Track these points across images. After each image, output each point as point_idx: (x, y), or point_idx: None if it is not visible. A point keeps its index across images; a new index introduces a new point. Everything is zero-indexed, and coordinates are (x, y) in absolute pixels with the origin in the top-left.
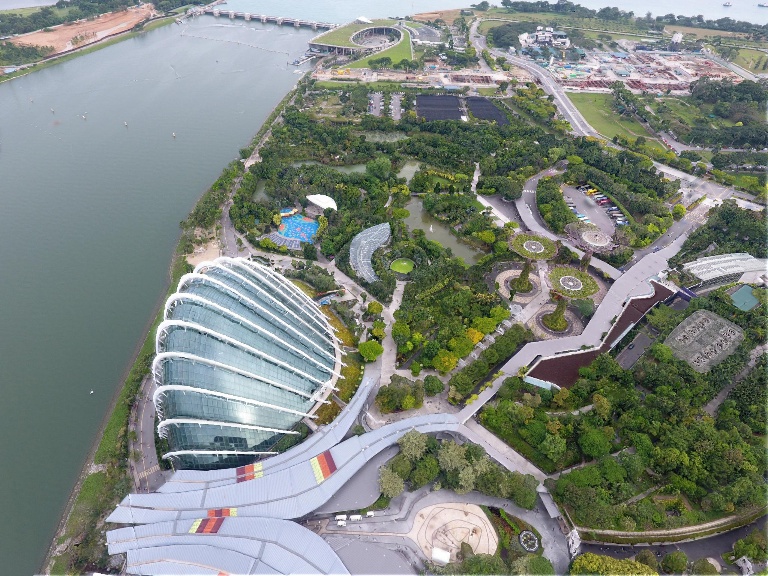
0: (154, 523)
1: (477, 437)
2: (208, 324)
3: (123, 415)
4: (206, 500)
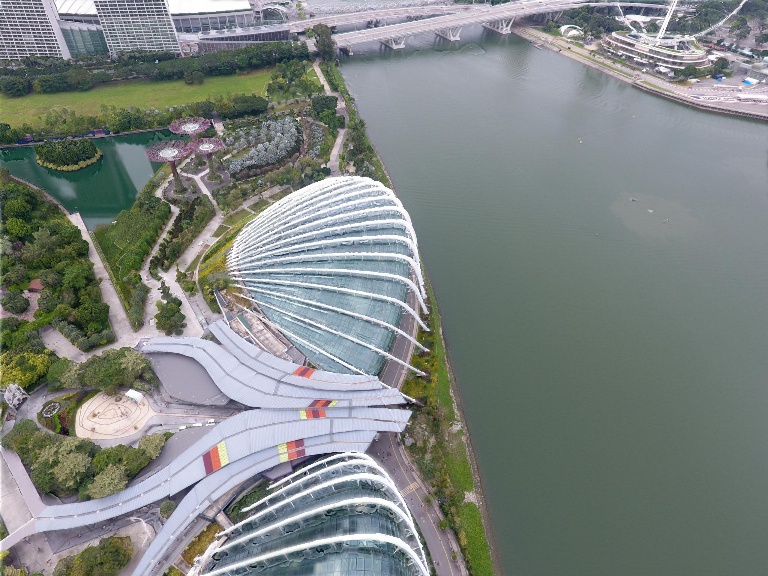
0: (369, 406)
1: (28, 499)
2: (336, 560)
3: (476, 568)
4: (329, 425)
